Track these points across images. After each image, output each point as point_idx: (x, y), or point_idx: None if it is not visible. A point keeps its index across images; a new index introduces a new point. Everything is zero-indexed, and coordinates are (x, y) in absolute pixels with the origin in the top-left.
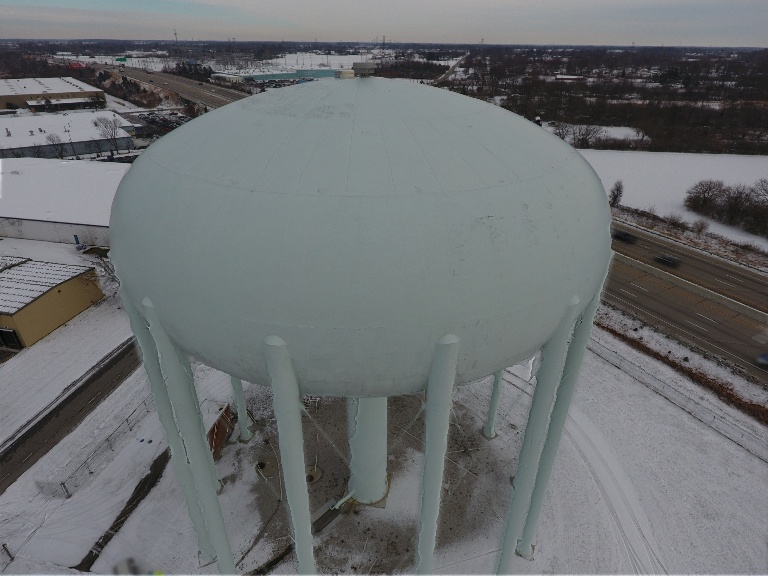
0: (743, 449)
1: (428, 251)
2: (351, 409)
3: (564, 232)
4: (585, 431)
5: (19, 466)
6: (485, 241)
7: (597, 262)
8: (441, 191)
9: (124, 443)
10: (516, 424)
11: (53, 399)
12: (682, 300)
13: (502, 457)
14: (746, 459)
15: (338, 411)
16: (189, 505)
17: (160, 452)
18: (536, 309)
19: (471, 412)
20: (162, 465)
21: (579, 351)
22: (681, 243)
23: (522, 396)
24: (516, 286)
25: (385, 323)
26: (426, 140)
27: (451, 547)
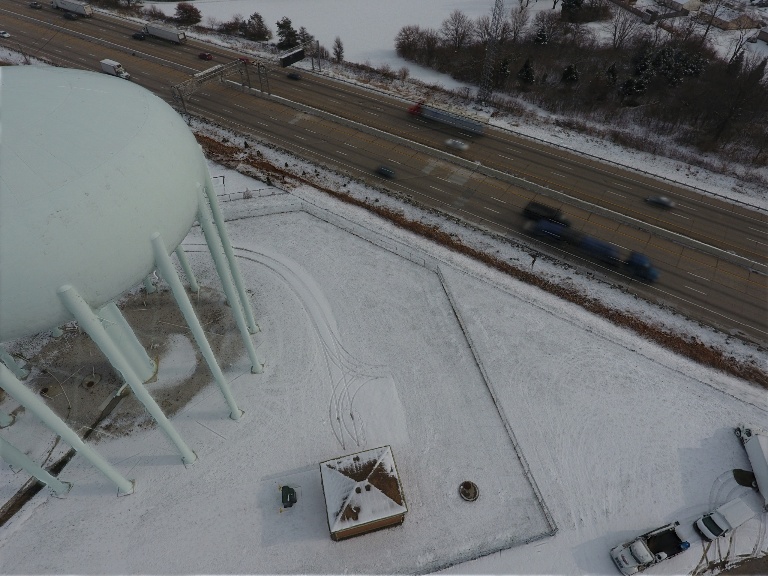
0: (398, 256)
1: (20, 246)
2: None
3: (124, 201)
4: (300, 278)
5: None
6: (60, 227)
7: (169, 205)
8: (17, 203)
9: None
10: (251, 289)
11: None
12: (380, 150)
13: None
14: (399, 262)
15: None
16: None
17: None
18: (121, 252)
19: (217, 291)
20: None
21: (214, 247)
22: (387, 94)
23: (256, 266)
24: (97, 245)
25: (12, 294)
26: (0, 161)
27: (208, 386)
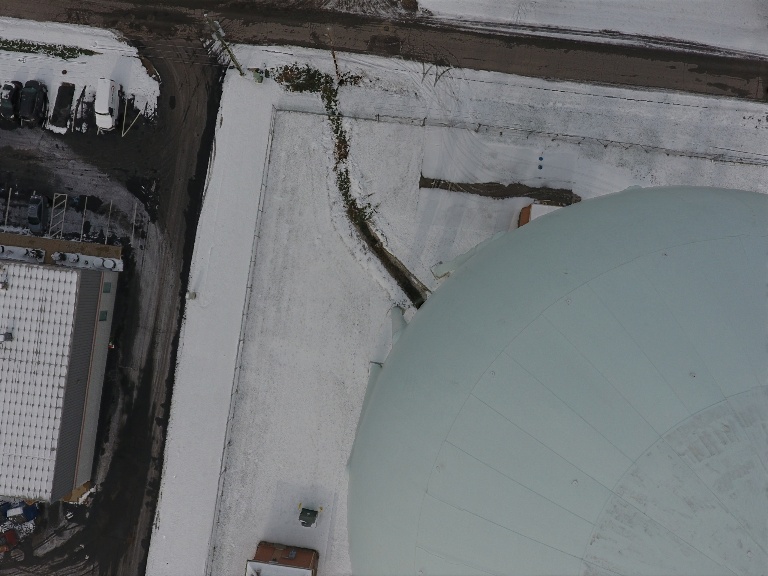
0: None
1: None
2: None
3: None
4: None
5: (504, 62)
6: None
7: None
8: None
9: (536, 143)
10: None
11: (589, 29)
12: None
13: None
14: None
15: None
16: None
17: (529, 184)
18: None
19: None
20: (515, 193)
21: None
22: None
23: None
24: None
25: None
26: None
27: None
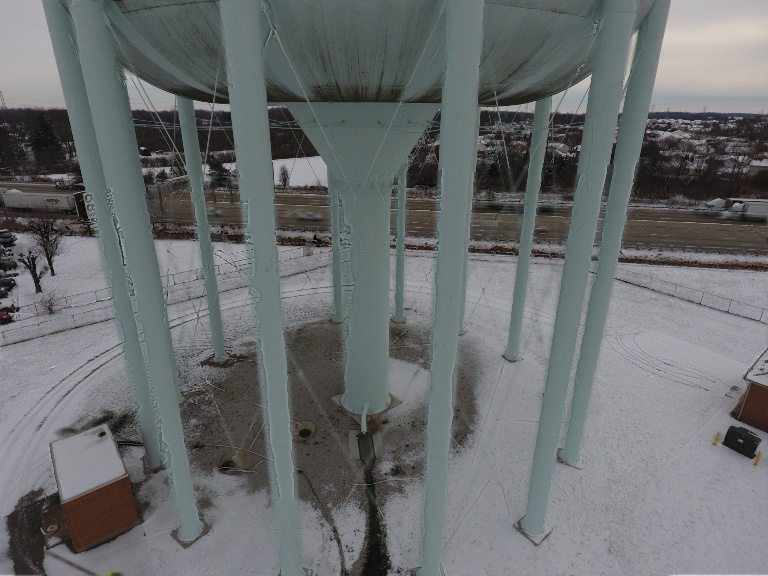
0: None
1: None
2: (261, 368)
3: None
4: None
5: None
6: None
7: None
8: None
9: None
10: (407, 306)
11: None
12: None
13: (427, 326)
14: None
15: (248, 376)
16: (287, 470)
17: None
18: None
19: None
20: None
21: None
22: None
23: None
24: None
25: None
26: None
27: (479, 386)
